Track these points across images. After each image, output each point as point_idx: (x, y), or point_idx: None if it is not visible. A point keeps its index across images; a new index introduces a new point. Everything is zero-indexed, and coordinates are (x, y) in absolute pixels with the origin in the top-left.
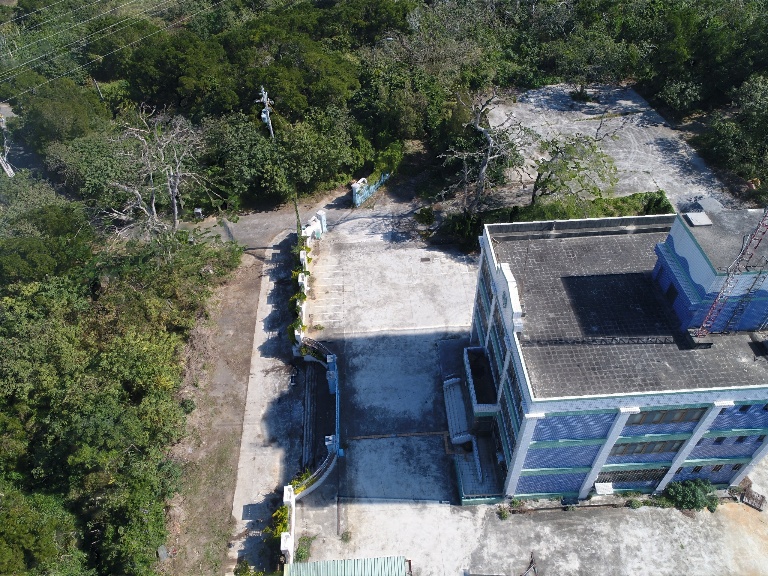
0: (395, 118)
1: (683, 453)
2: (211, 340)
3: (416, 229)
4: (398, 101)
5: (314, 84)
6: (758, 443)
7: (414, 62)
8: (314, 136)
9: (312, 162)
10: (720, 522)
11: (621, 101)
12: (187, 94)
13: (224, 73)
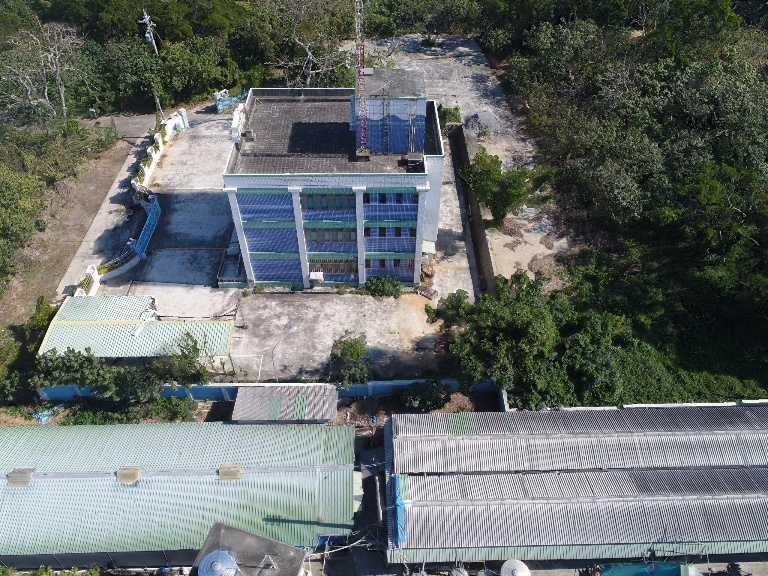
0: (255, 43)
1: (359, 242)
2: (75, 192)
3: None
4: (257, 30)
5: (205, 21)
6: (413, 238)
7: (289, 7)
8: (188, 54)
9: (184, 74)
10: (398, 304)
11: (460, 48)
12: (106, 28)
13: (129, 7)
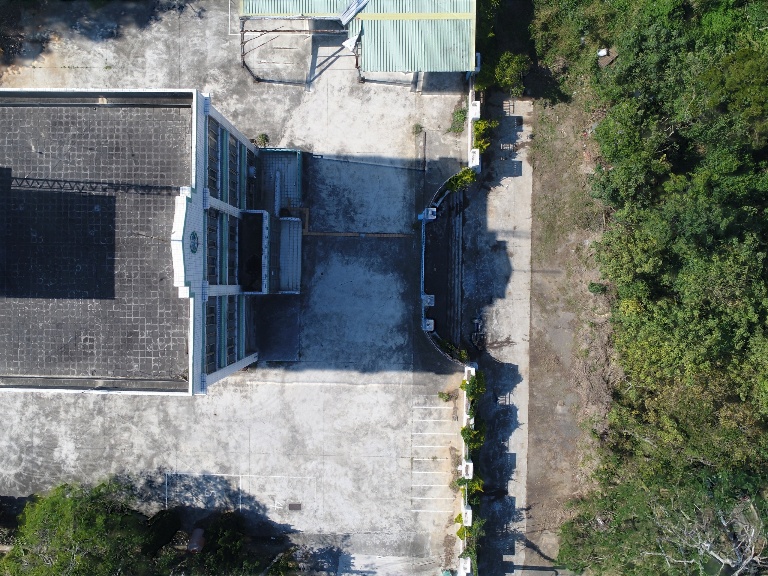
0: None
1: None
2: (584, 398)
3: (301, 575)
4: None
5: None
6: None
7: None
8: None
9: None
10: None
11: None
12: None
13: None
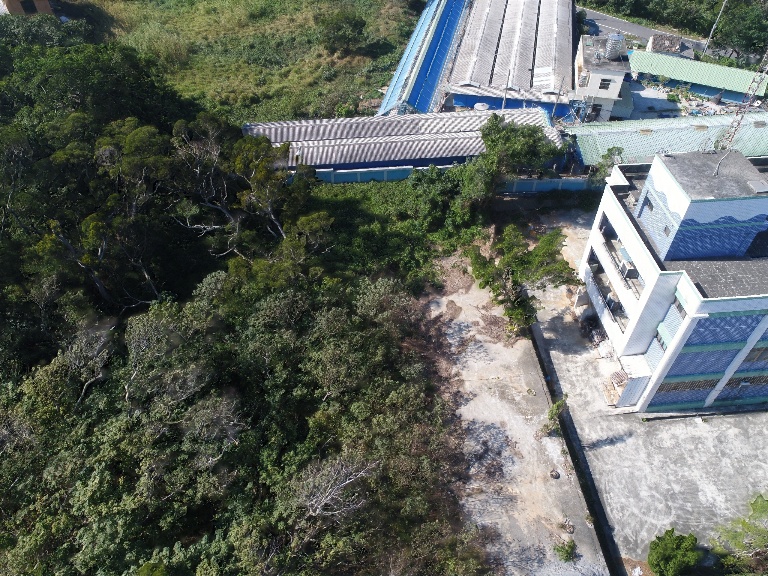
0: None
1: None
2: None
3: None
4: None
5: None
6: None
7: None
8: None
9: None
10: None
11: None
12: None
13: None
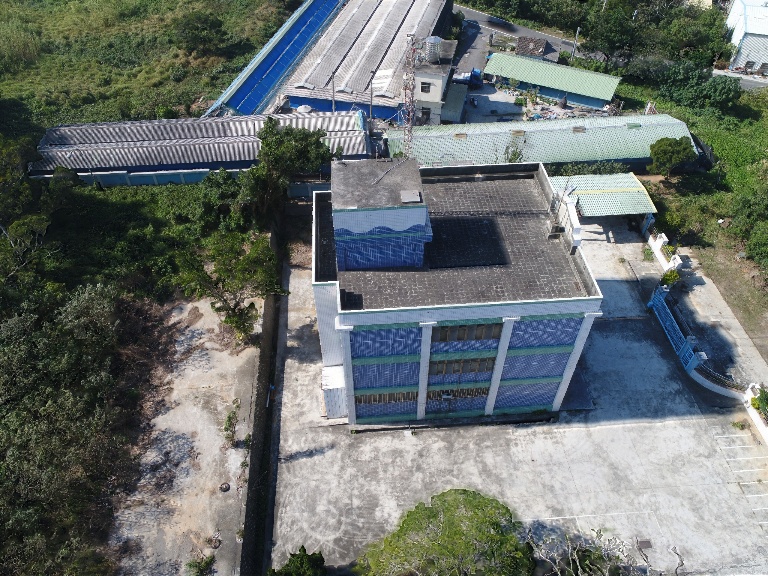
0: None
1: None
2: None
3: None
4: None
5: None
6: None
7: None
8: None
9: None
10: None
11: None
12: None
13: None
